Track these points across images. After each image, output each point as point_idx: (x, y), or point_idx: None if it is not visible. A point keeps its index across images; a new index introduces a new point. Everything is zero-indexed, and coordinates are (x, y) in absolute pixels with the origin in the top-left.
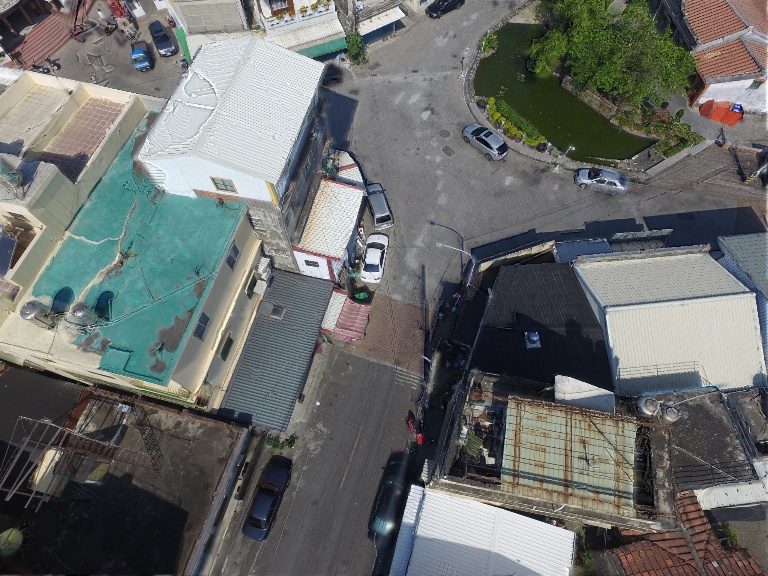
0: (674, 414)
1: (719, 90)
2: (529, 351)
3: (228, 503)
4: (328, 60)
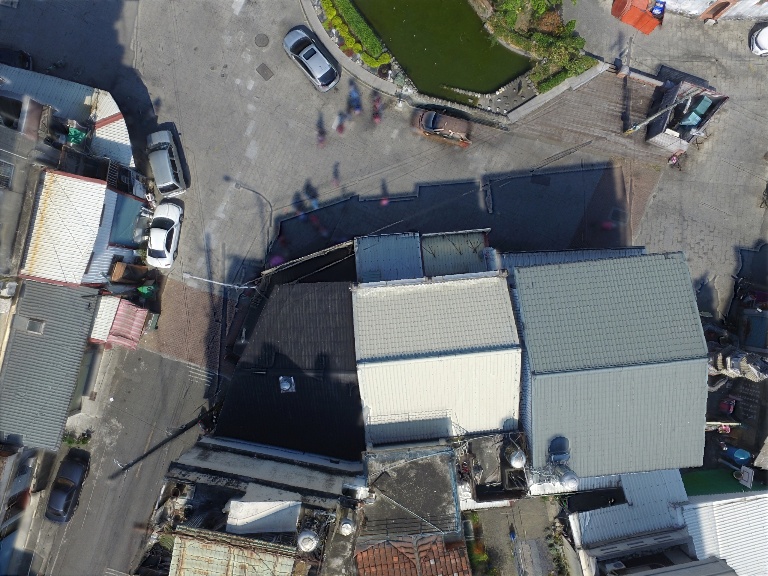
0: (348, 530)
1: None
2: (283, 395)
3: (29, 494)
4: None
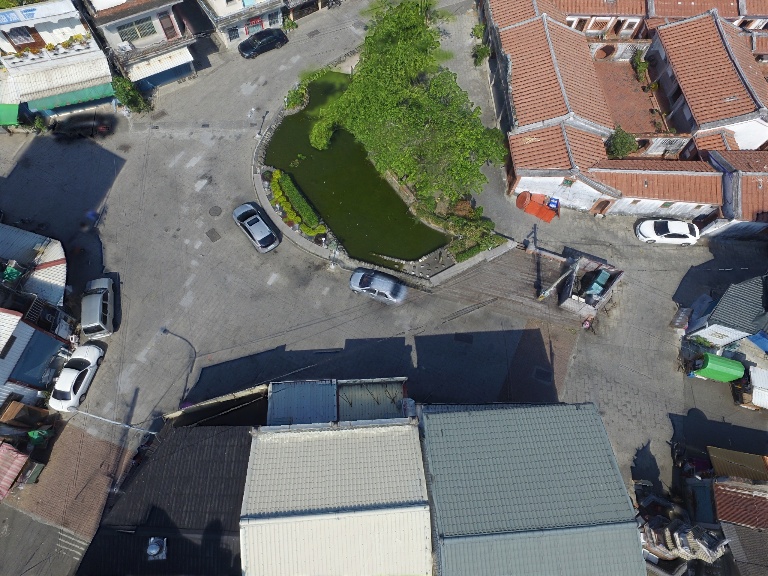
0: None
1: (532, 183)
2: (150, 564)
3: None
4: (104, 104)
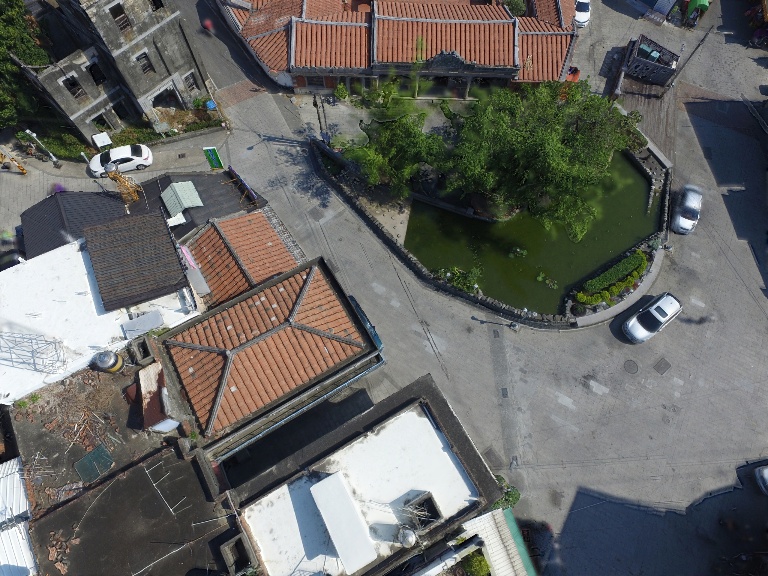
0: None
1: None
2: None
3: None
4: None
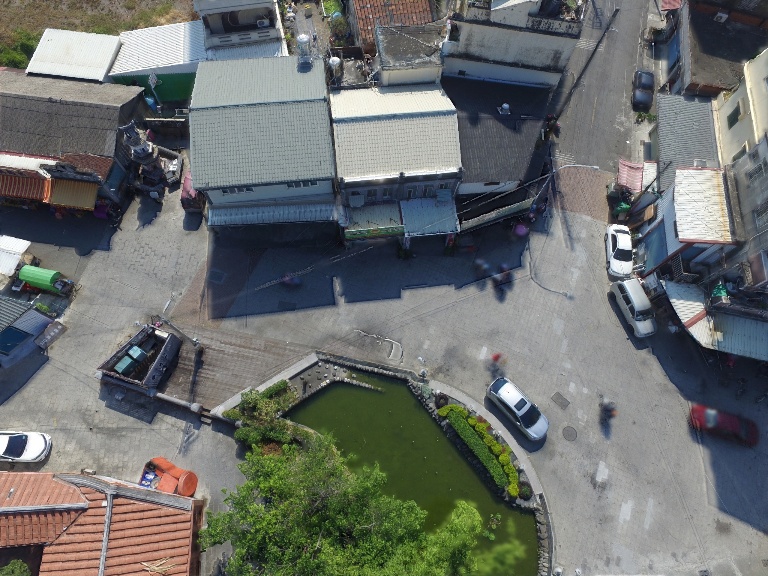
0: None
1: None
2: None
3: None
4: None
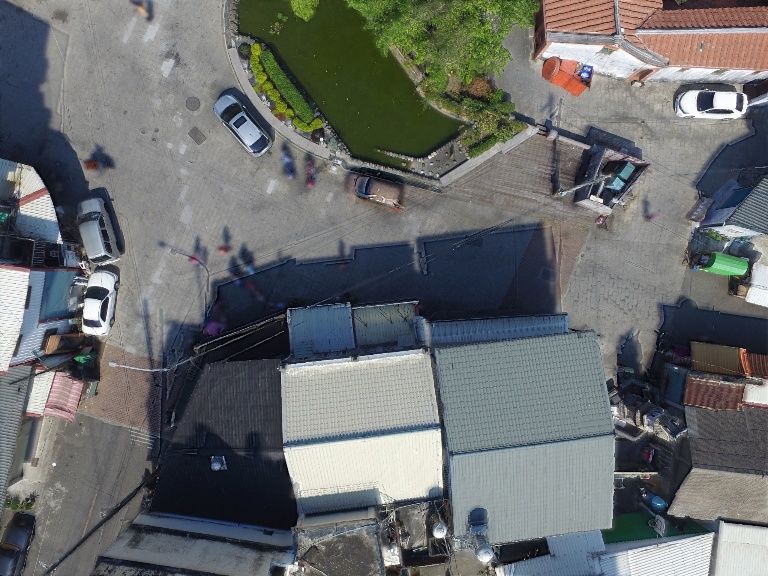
0: None
1: (565, 48)
2: (216, 473)
3: None
4: None
